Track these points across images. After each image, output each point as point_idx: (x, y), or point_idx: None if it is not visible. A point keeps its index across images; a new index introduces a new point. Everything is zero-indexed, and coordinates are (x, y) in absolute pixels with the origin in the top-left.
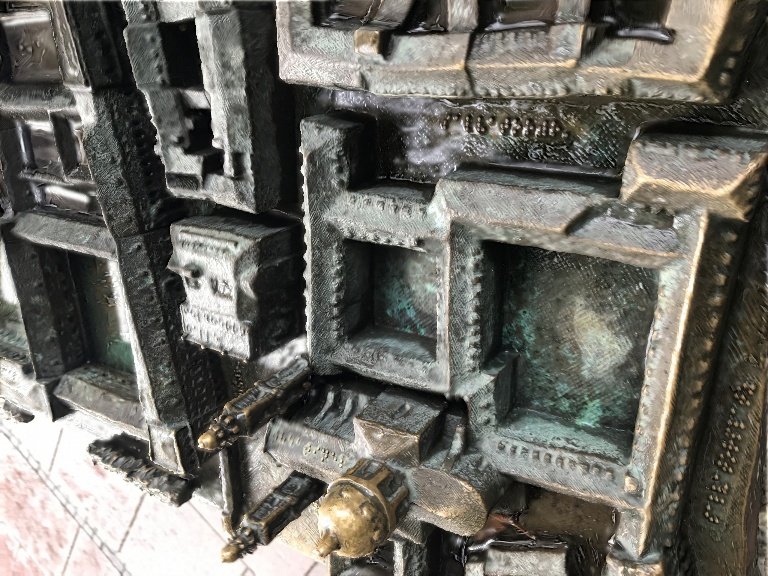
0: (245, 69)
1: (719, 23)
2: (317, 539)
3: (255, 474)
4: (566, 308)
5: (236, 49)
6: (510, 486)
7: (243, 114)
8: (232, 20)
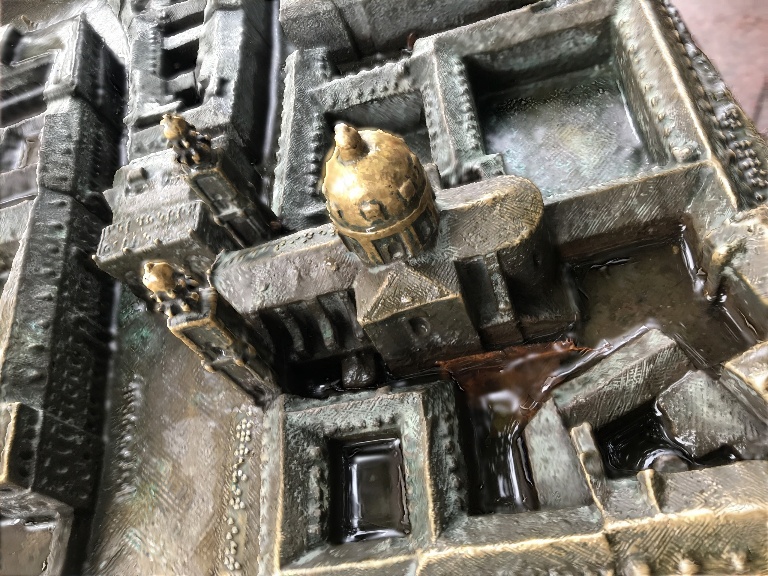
0: (242, 37)
1: None
2: None
3: (111, 571)
4: (545, 132)
5: (236, 28)
6: None
7: (234, 58)
8: (237, 14)
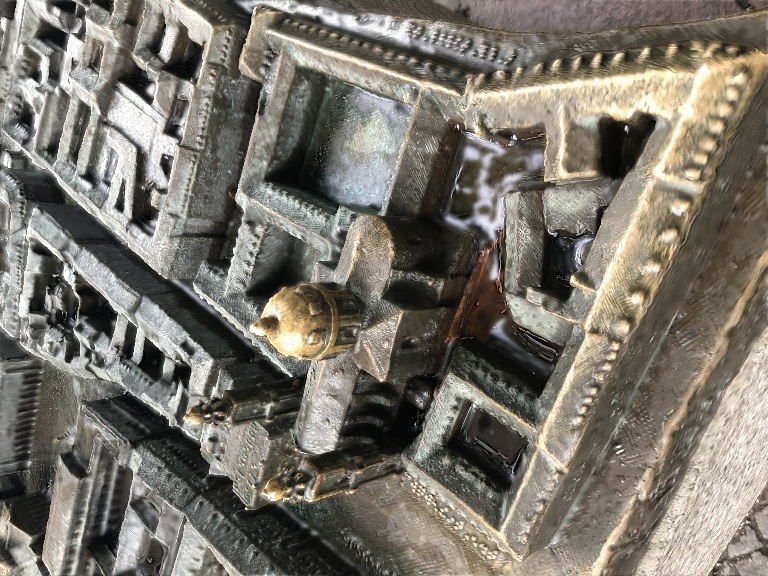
0: (163, 310)
1: (201, 19)
2: None
3: None
4: (349, 155)
5: (154, 309)
6: (424, 224)
7: (174, 326)
8: (145, 302)
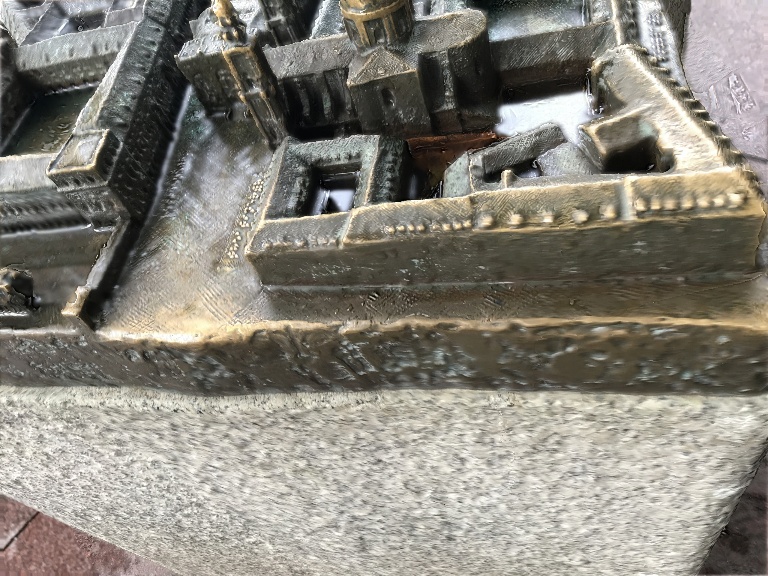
0: None
1: None
2: (215, 302)
3: (149, 258)
4: (521, 22)
5: None
6: (494, 78)
7: None
8: None
